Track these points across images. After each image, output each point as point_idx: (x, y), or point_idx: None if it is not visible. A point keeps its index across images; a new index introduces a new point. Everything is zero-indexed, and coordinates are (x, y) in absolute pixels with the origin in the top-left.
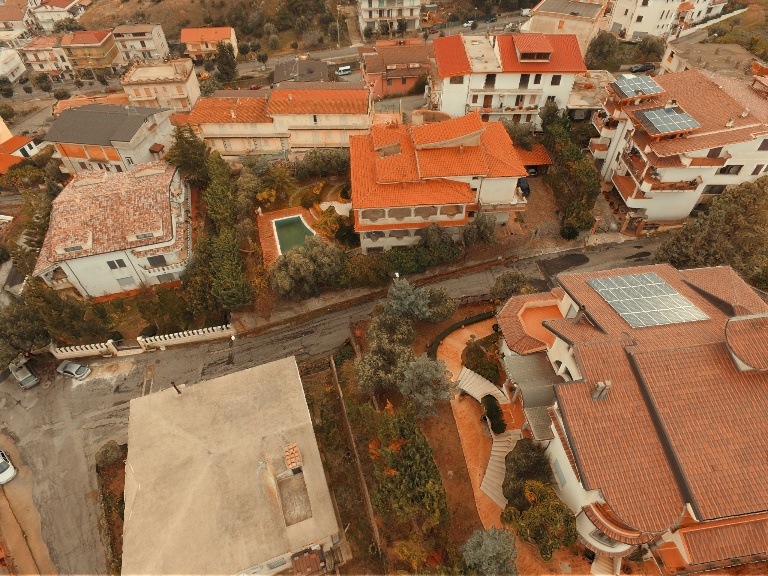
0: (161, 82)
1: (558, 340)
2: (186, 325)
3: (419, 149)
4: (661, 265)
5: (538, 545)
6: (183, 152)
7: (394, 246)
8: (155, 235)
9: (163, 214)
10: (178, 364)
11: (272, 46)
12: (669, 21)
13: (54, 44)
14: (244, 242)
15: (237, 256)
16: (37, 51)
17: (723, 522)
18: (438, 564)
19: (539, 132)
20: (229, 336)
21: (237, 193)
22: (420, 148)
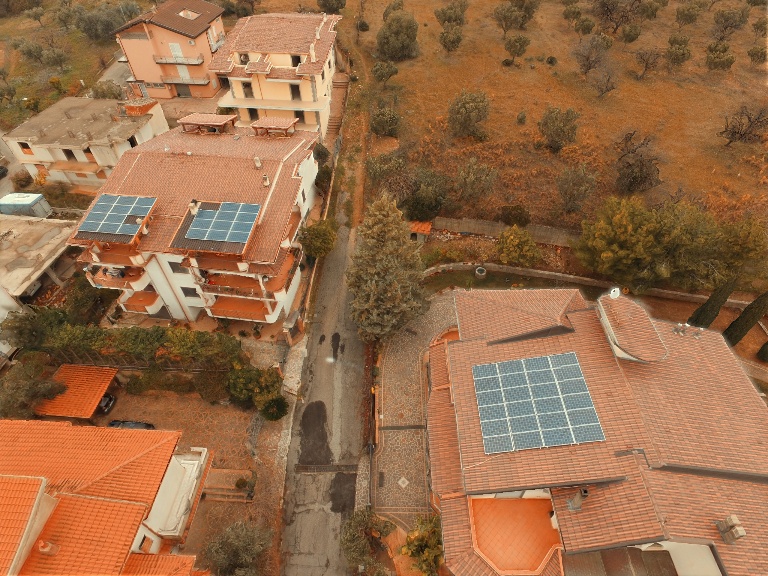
0: None
1: None
2: None
3: None
4: (452, 351)
5: None
6: None
7: None
8: None
9: None
10: None
11: None
12: None
13: None
14: None
15: None
16: None
17: None
18: None
19: (14, 353)
20: None
21: None
22: None
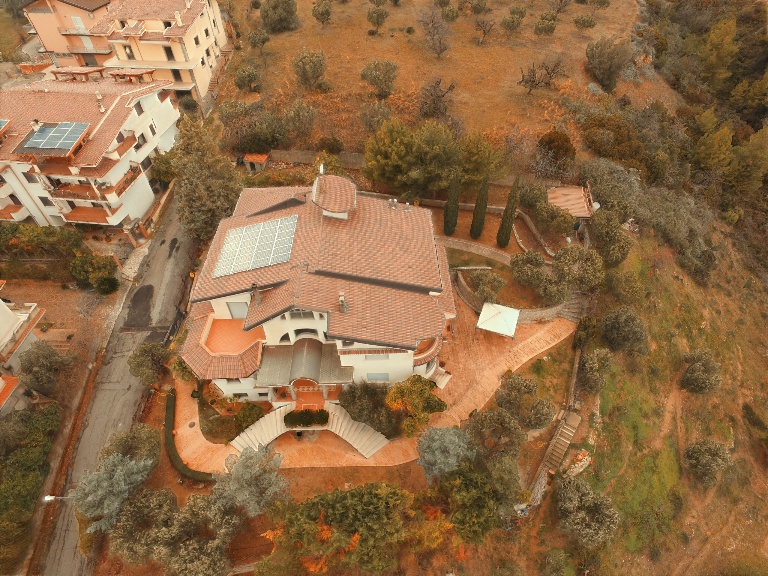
0: None
1: (268, 325)
2: None
3: None
4: (221, 224)
5: (433, 412)
6: None
7: None
8: None
9: None
10: None
11: None
12: None
13: None
14: None
15: None
16: None
17: None
18: (438, 510)
19: None
20: None
21: None
22: None
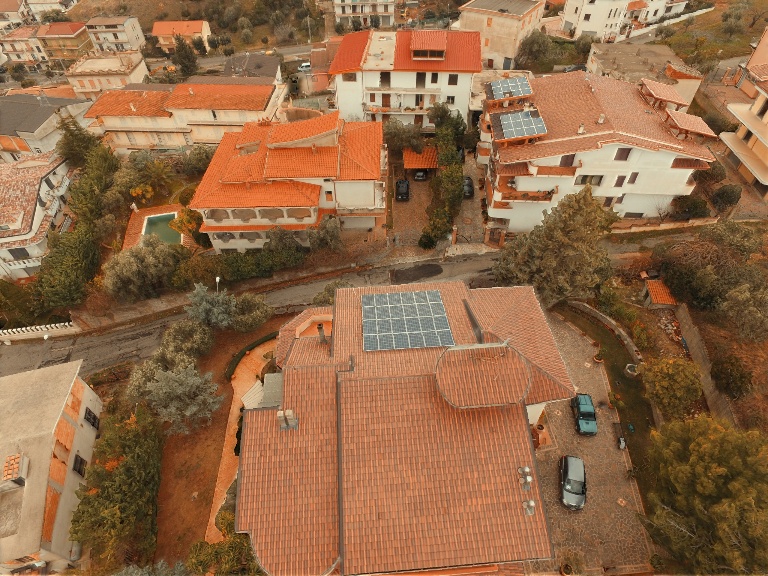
0: (104, 74)
1: None
2: (32, 320)
3: (271, 148)
4: (455, 282)
5: None
6: (69, 144)
7: (248, 248)
8: (11, 228)
9: (27, 207)
10: (18, 360)
11: (245, 40)
12: (618, 20)
13: (30, 35)
14: (106, 238)
15: (85, 252)
16: (13, 41)
17: (399, 575)
18: None
19: None
20: (75, 334)
21: (110, 188)
22: (272, 147)
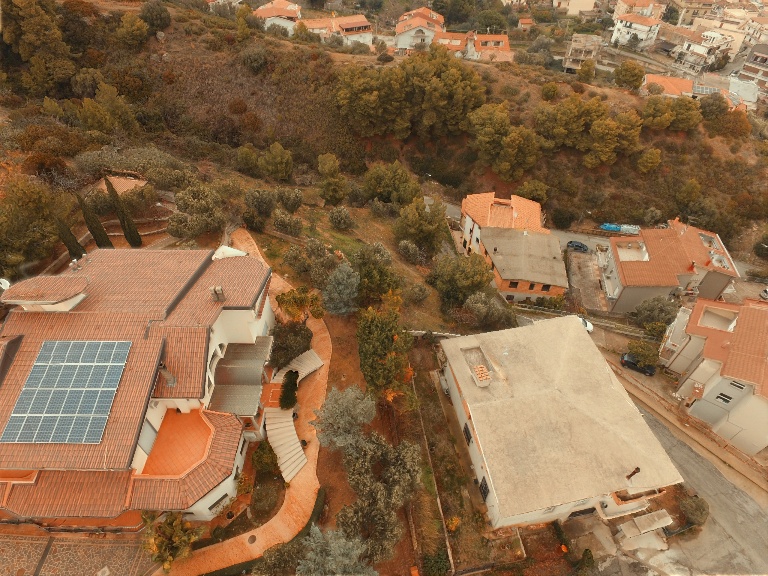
0: None
1: None
2: None
3: None
4: None
5: None
6: None
7: None
8: None
9: None
10: None
11: None
12: None
13: None
14: None
15: None
16: None
17: None
18: None
19: None
20: None
21: None
22: None
